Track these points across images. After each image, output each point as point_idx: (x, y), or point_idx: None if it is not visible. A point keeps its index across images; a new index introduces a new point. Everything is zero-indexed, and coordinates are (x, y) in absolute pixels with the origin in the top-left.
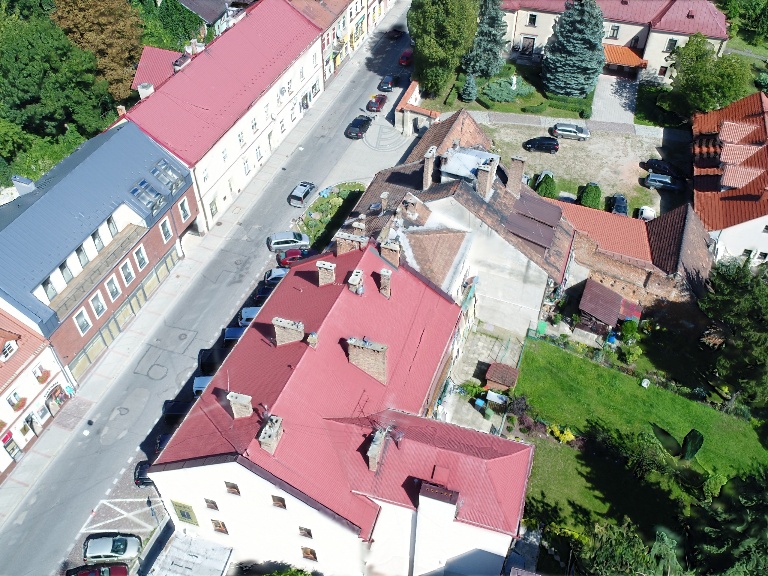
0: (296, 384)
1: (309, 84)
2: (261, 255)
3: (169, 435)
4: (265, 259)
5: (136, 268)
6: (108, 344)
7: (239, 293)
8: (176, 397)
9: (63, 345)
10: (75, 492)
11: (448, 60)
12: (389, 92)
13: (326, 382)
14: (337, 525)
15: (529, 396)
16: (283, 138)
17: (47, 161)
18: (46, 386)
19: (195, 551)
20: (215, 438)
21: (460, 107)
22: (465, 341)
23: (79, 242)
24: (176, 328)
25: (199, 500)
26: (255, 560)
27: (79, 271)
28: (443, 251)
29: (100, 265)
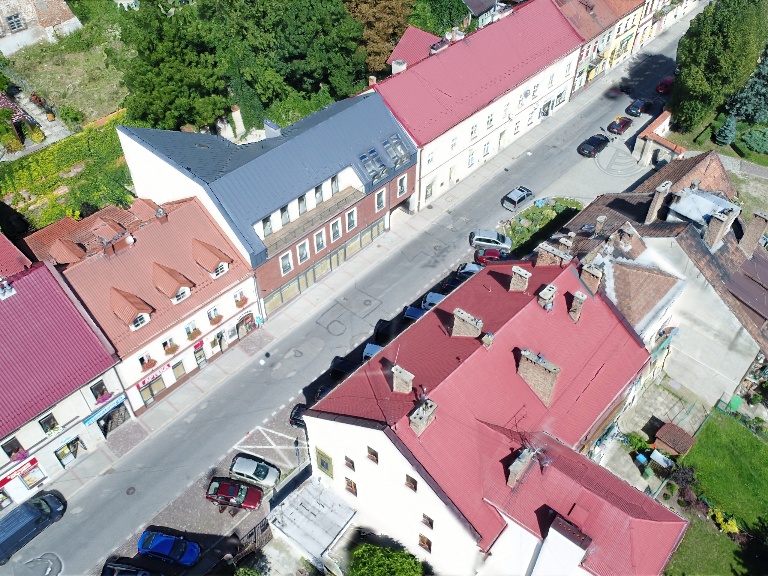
0: (459, 377)
1: (555, 92)
2: (461, 247)
3: (330, 388)
4: (463, 252)
5: (345, 228)
6: (302, 290)
7: (430, 277)
8: (346, 356)
9: (265, 279)
10: (239, 411)
11: (712, 96)
12: (636, 117)
13: (489, 385)
14: (460, 525)
15: (699, 470)
16: (514, 140)
17: (296, 113)
18: (241, 311)
19: (323, 501)
20: (370, 403)
21: (710, 148)
22: (644, 391)
23: (303, 191)
24: (364, 293)
25: (340, 455)
26: (374, 530)
27: (296, 217)
28: (648, 291)
29: (315, 217)
